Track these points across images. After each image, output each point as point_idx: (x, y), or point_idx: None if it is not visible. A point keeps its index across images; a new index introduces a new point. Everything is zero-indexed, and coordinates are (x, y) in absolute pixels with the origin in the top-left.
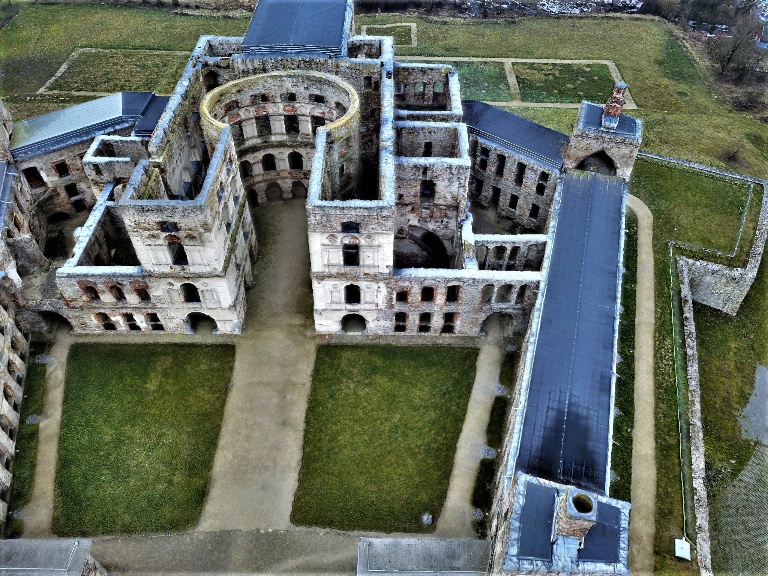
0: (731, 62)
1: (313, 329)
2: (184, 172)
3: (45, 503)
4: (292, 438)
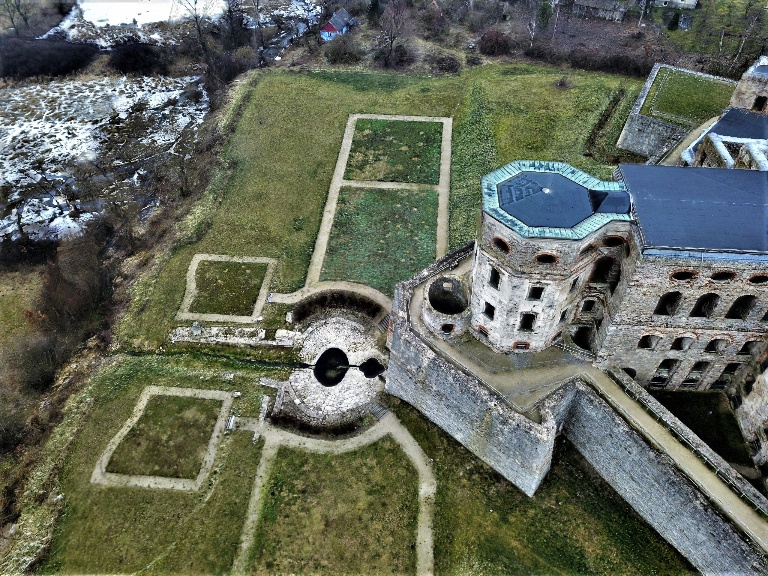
0: (392, 51)
1: None
2: None
3: None
4: None
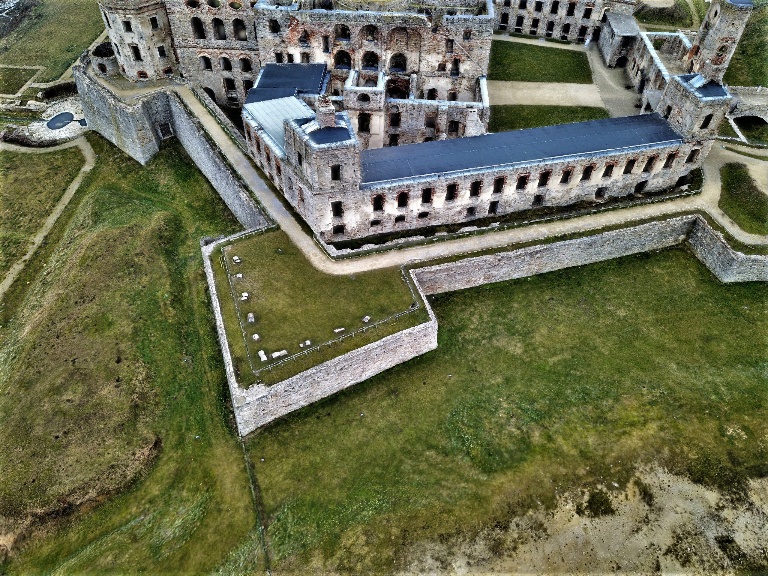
0: None
1: None
2: None
3: None
4: (547, 85)
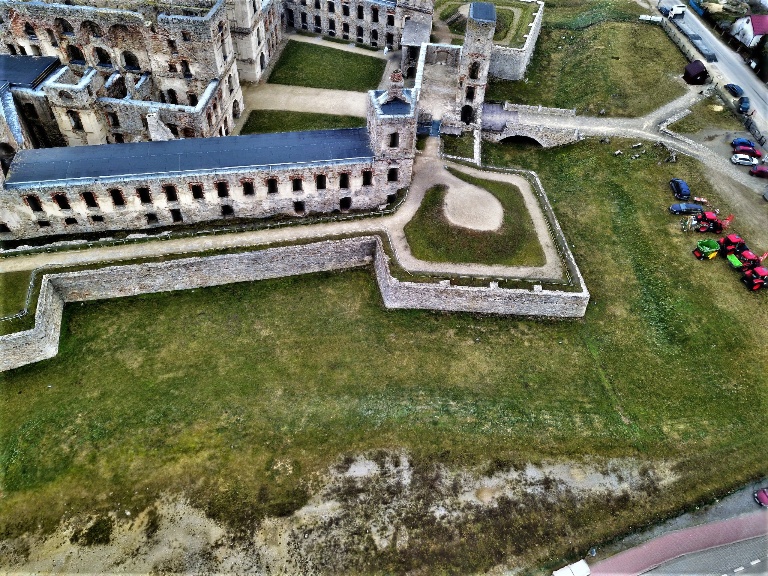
0: None
1: (253, 83)
2: (122, 57)
3: None
4: (328, 92)
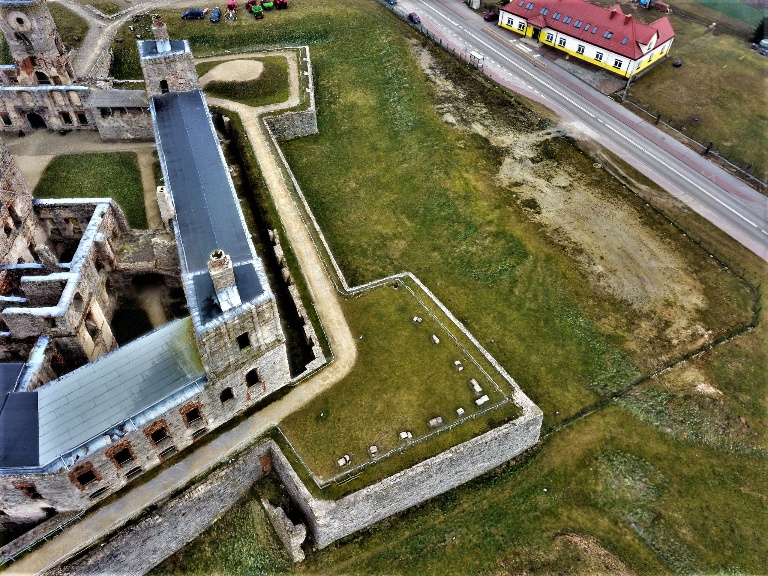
0: None
1: None
2: None
3: (143, 163)
4: None
